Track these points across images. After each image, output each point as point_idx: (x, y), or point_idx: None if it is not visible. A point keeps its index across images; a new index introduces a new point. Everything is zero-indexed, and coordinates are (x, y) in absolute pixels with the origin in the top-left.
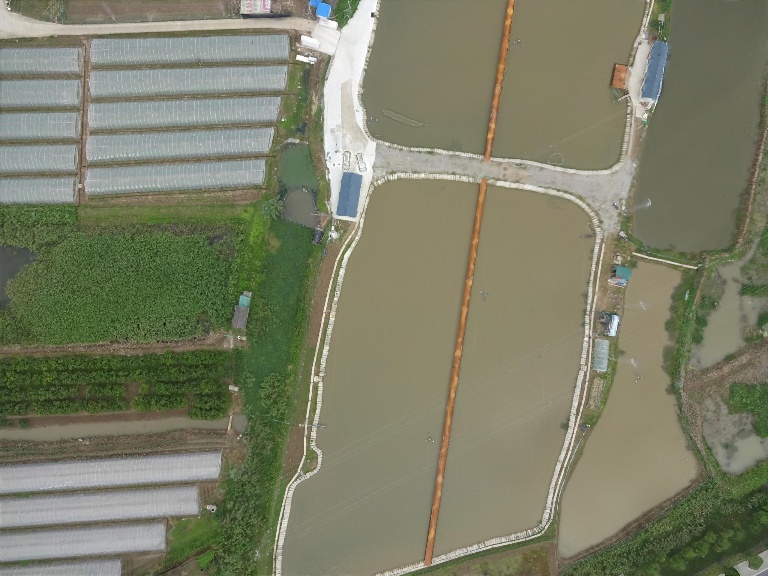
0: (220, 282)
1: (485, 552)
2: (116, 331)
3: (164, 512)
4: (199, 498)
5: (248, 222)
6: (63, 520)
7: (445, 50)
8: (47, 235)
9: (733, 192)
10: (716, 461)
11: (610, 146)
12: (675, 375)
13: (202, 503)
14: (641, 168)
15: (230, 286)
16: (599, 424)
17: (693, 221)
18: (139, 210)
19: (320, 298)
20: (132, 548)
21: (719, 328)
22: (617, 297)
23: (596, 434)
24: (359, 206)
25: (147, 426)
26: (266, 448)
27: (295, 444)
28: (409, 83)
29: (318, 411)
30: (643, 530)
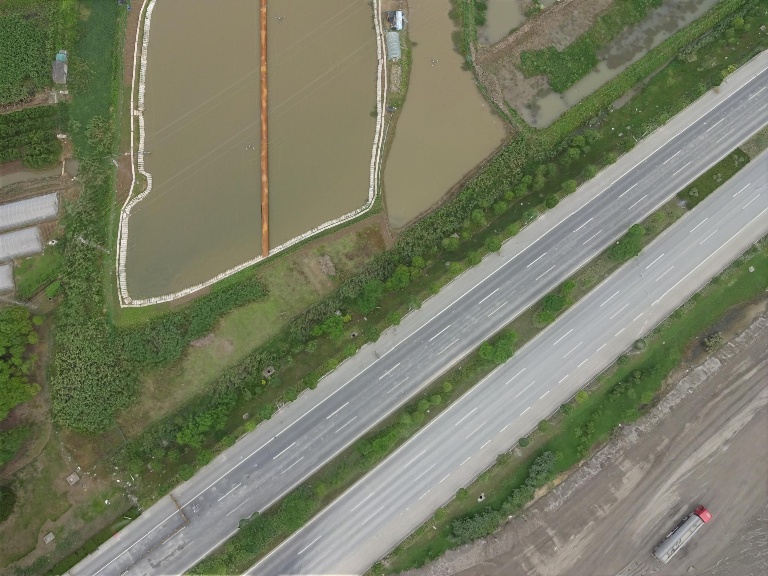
0: (38, 49)
1: (318, 234)
2: None
3: (8, 253)
4: (41, 237)
5: None
6: None
7: None
8: None
9: None
10: (522, 119)
11: None
12: (466, 52)
13: (44, 241)
14: None
15: (47, 51)
16: (406, 107)
17: None
18: None
19: (130, 45)
20: None
21: (500, 11)
22: None
23: (405, 116)
24: None
25: None
26: (97, 180)
27: (124, 171)
28: None
29: (142, 140)
30: (464, 187)
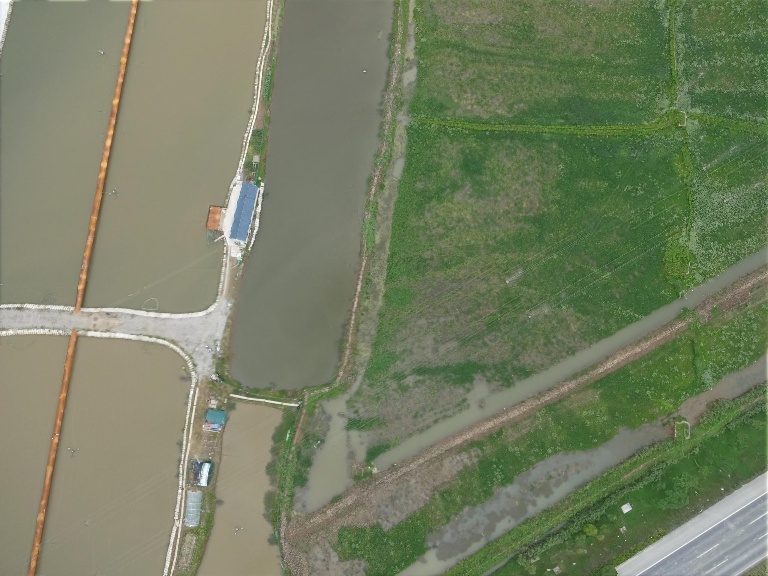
0: None
1: None
2: None
3: None
4: None
5: None
6: None
7: (40, 206)
8: None
9: (336, 323)
10: None
11: (207, 287)
12: (276, 523)
13: None
14: (238, 307)
15: None
16: None
17: (296, 356)
18: None
19: None
20: None
21: (328, 467)
22: (213, 443)
23: None
24: None
25: None
26: None
27: None
28: (3, 241)
29: None
30: None
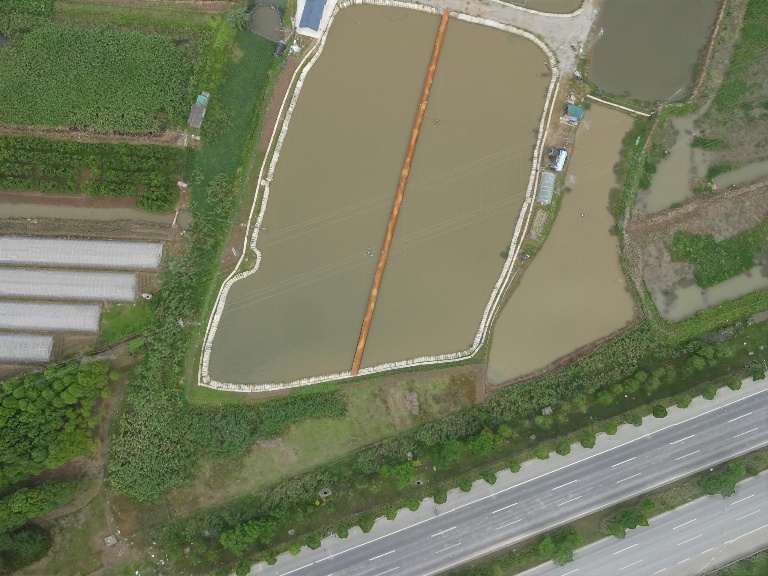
0: (181, 82)
1: (412, 368)
2: (75, 117)
3: (101, 295)
4: (136, 286)
5: (214, 30)
6: (2, 291)
7: None
8: (22, 21)
9: (692, 48)
10: (654, 305)
11: None
12: (619, 216)
13: (139, 291)
14: (602, 16)
15: (190, 86)
16: (539, 257)
17: (650, 72)
18: (112, 9)
19: (275, 106)
20: (65, 325)
21: (668, 178)
22: (568, 135)
23: (535, 266)
24: (322, 24)
25: (95, 213)
26: (207, 243)
27: (236, 242)
28: None
29: (262, 214)
30: (574, 363)
